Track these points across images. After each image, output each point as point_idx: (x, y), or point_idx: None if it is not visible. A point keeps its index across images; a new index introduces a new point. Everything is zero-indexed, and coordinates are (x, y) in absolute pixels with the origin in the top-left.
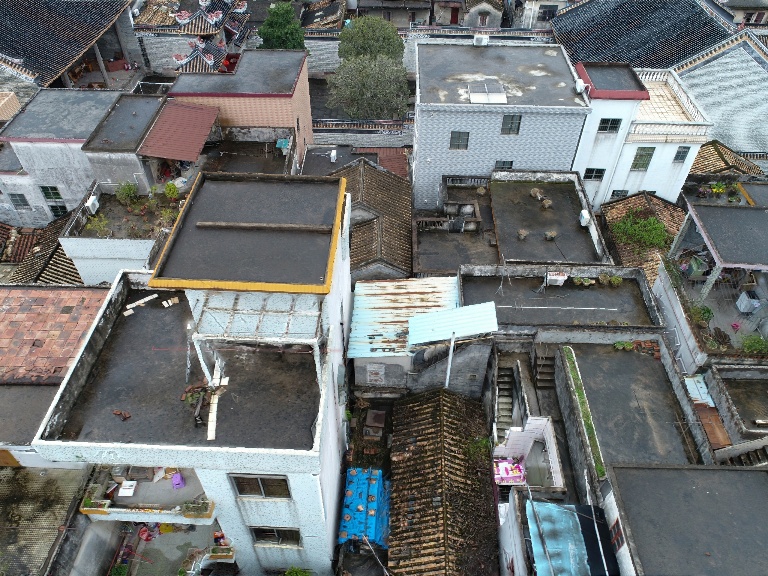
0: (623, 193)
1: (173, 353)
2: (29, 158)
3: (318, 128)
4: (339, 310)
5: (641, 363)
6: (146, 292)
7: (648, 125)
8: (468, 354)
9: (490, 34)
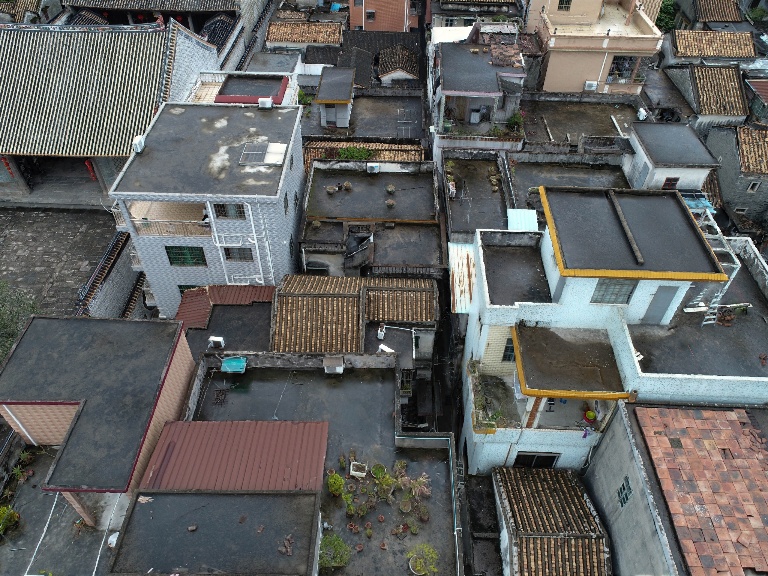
0: None
1: (691, 340)
2: None
3: None
4: None
5: (523, 170)
6: None
7: None
8: None
9: None
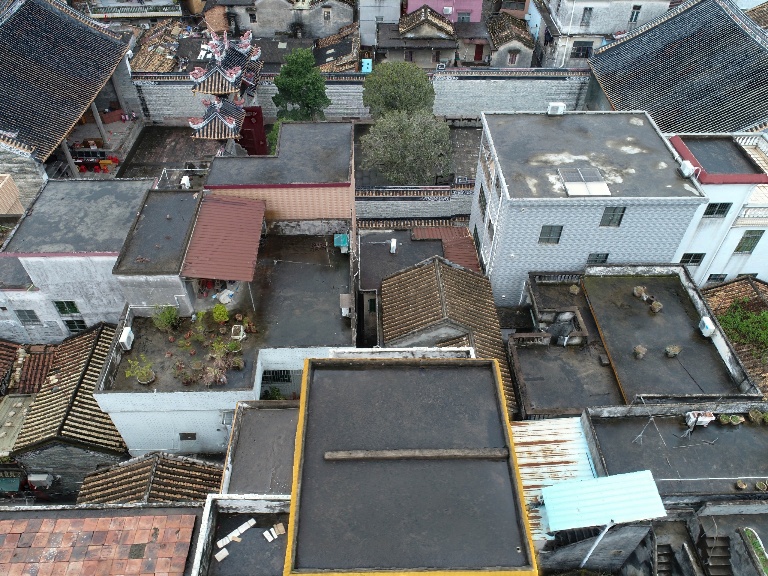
0: (721, 276)
1: None
2: (41, 273)
3: (356, 196)
4: None
5: None
6: (239, 516)
7: (761, 208)
8: (620, 535)
9: (523, 75)
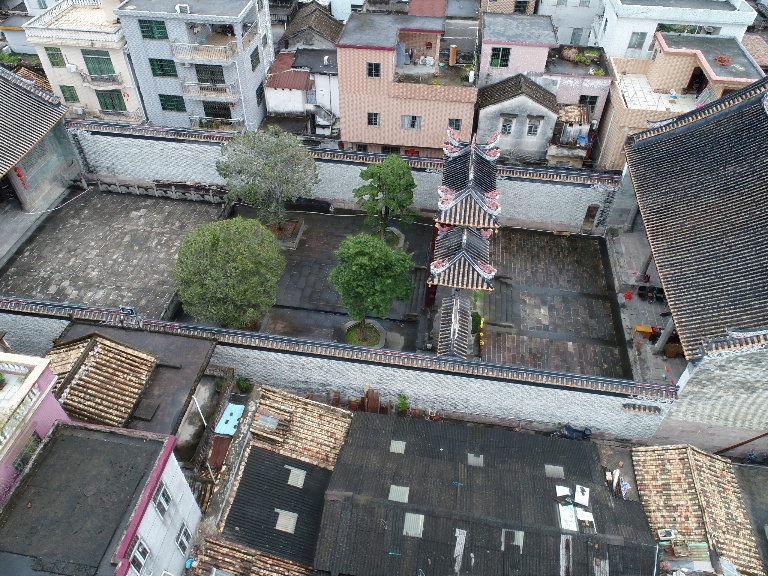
0: None
1: None
2: None
3: None
4: None
5: None
6: None
7: None
8: None
9: None
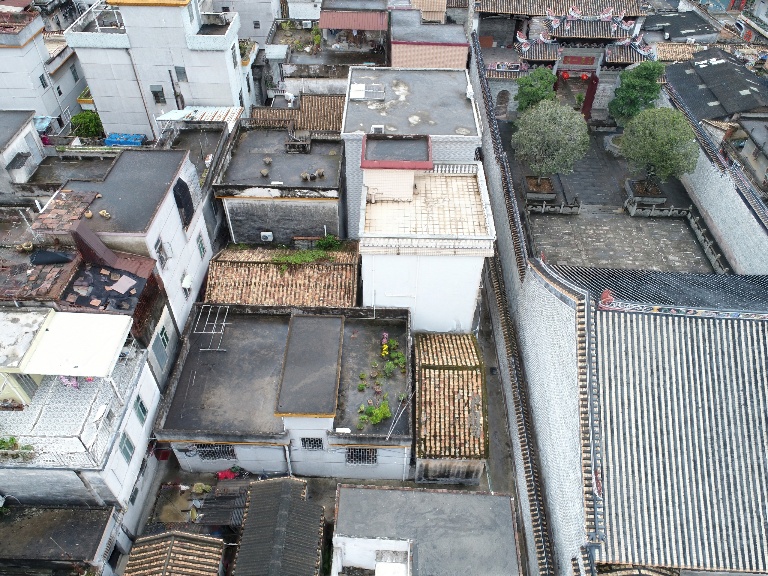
0: None
1: None
2: None
3: None
4: (167, 60)
5: None
6: None
7: None
8: None
9: None
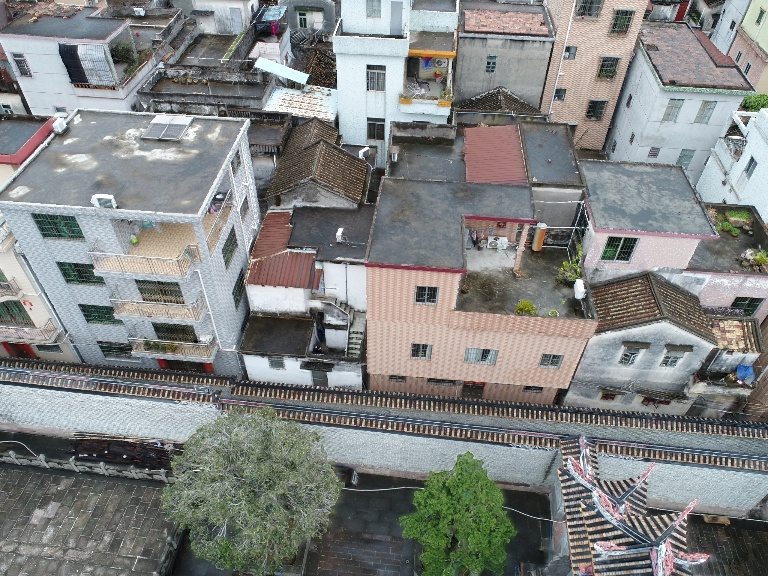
0: None
1: None
2: None
3: None
4: None
5: None
6: None
7: None
8: None
9: None
